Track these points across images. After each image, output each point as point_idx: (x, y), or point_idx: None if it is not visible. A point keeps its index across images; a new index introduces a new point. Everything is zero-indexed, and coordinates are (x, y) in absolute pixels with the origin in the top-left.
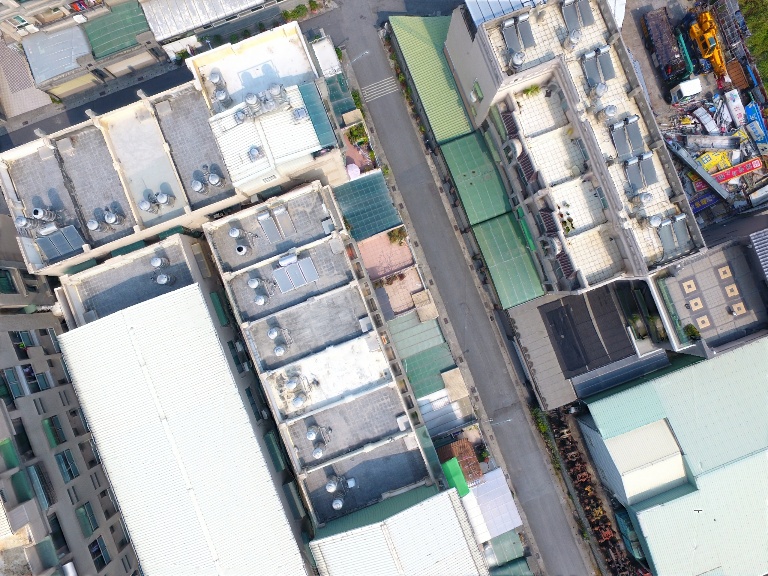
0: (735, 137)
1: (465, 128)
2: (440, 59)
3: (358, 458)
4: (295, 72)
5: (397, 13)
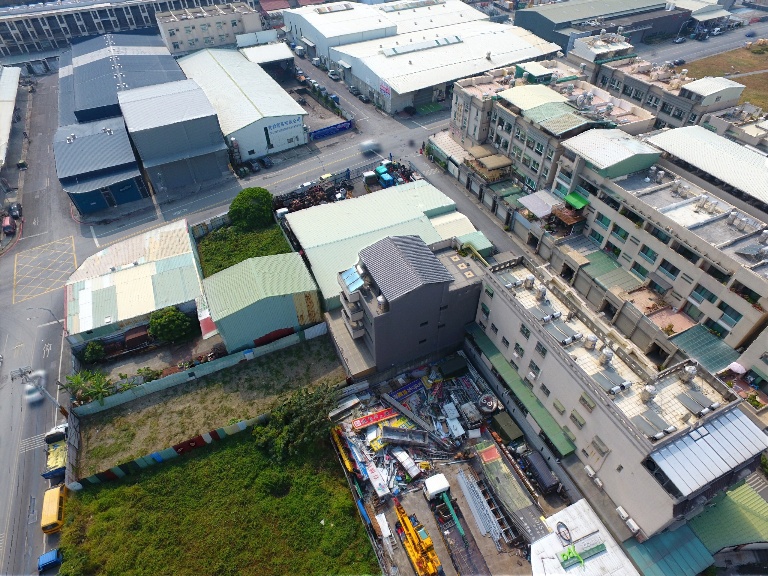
0: (387, 437)
1: None
2: None
3: None
4: None
5: None
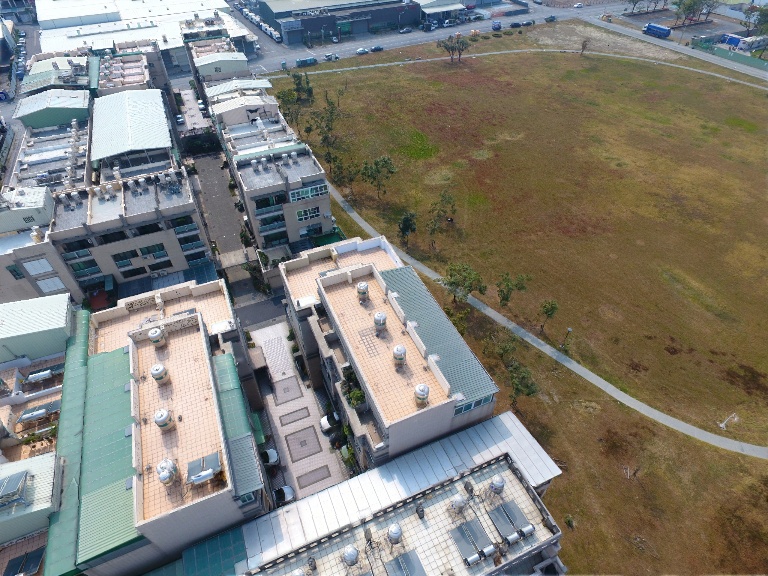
0: None
1: None
2: None
3: None
4: None
5: None
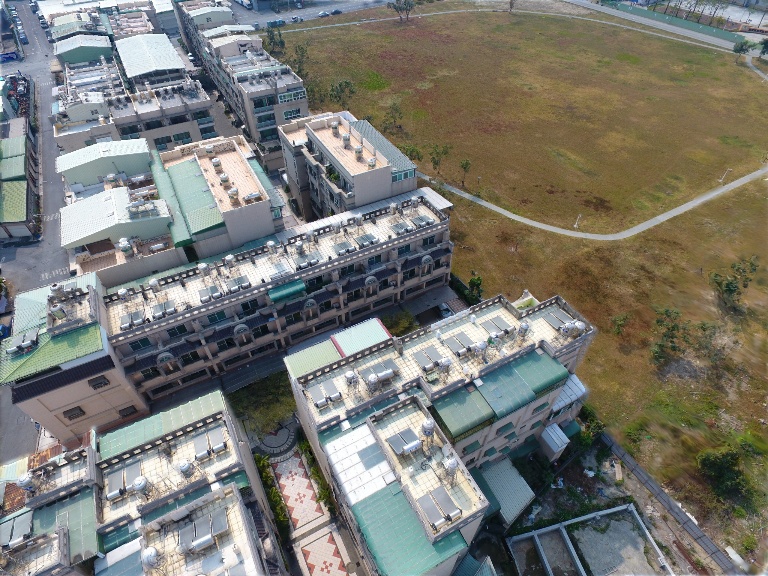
0: None
1: (6, 183)
2: (3, 204)
3: None
4: (67, 133)
5: (25, 247)
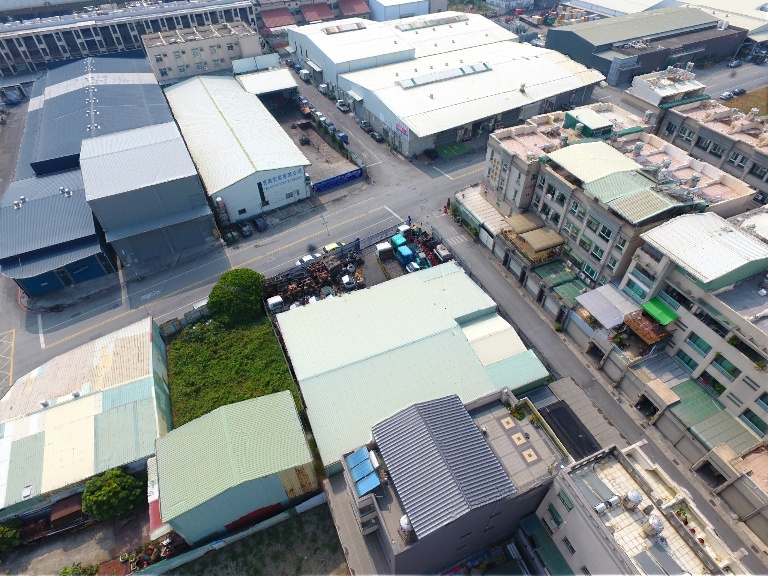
0: None
1: None
2: None
3: (767, 307)
4: None
5: None
